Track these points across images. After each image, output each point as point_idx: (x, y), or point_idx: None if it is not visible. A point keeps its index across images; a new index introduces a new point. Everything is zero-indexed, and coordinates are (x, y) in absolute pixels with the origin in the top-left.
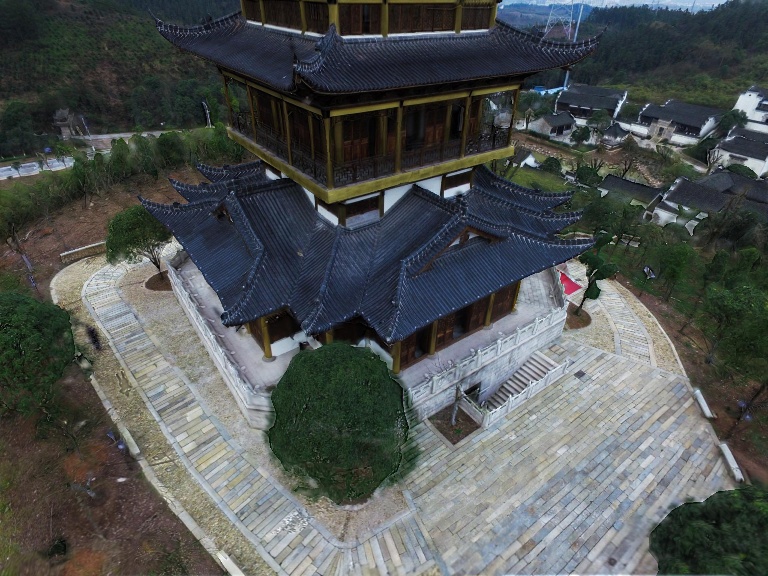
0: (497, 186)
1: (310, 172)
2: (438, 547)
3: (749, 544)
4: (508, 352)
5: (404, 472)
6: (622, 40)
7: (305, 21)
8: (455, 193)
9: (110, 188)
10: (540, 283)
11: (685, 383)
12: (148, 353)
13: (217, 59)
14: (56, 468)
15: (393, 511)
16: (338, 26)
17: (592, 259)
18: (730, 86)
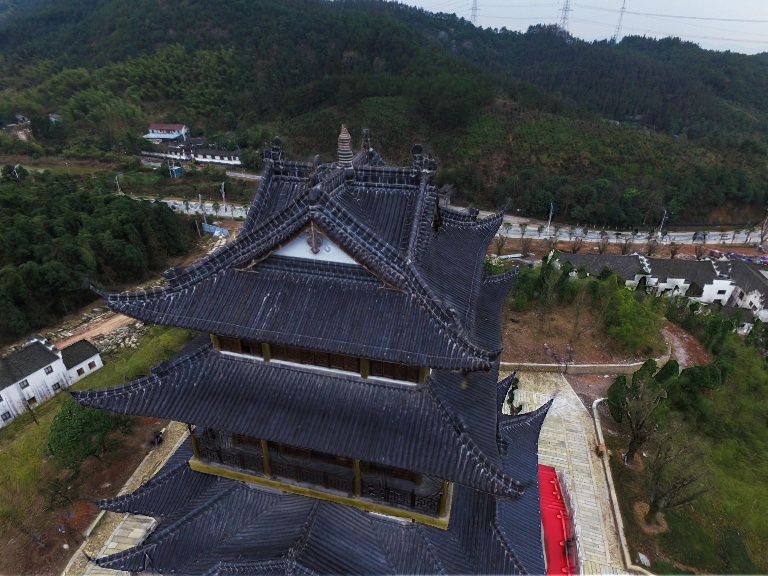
0: (493, 533)
1: None
2: None
3: None
4: None
5: None
6: None
7: None
8: None
9: None
10: None
11: None
12: None
13: None
14: (70, 506)
15: None
16: (218, 343)
17: None
18: None
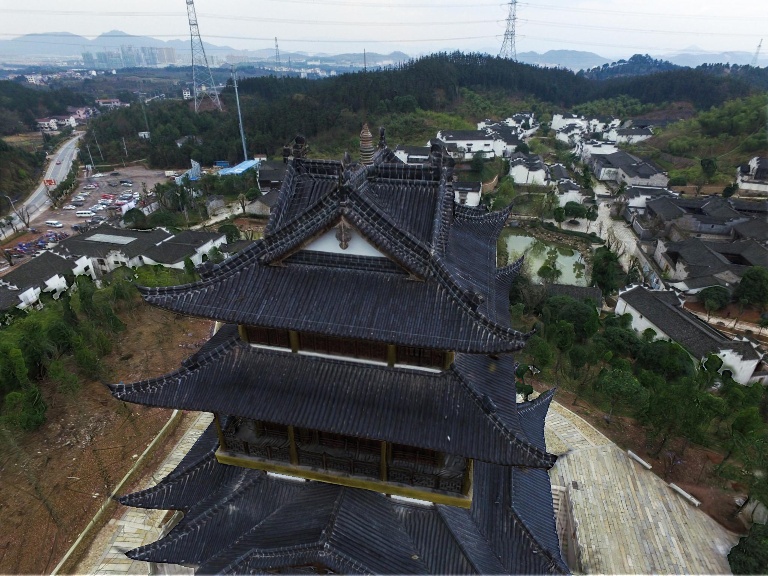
0: None
1: (426, 484)
2: None
3: None
4: None
5: None
6: (276, 112)
7: (394, 356)
8: None
9: None
10: None
11: (617, 448)
12: None
13: (284, 421)
14: None
15: None
16: None
17: (526, 389)
18: None
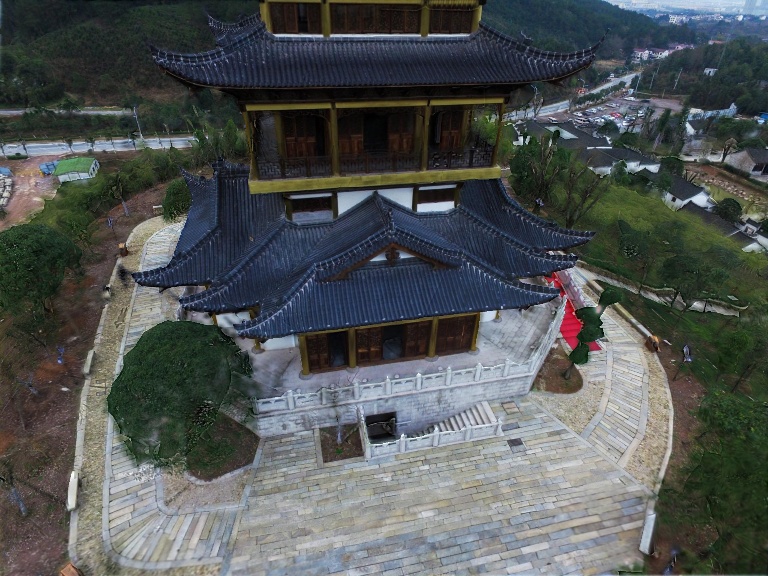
0: (508, 211)
1: None
2: (235, 549)
3: None
4: (433, 390)
5: (261, 469)
6: None
7: None
8: (434, 209)
9: None
10: (531, 330)
11: (647, 500)
12: (154, 298)
13: None
14: (38, 365)
15: (225, 499)
16: (270, 24)
17: (587, 316)
18: None
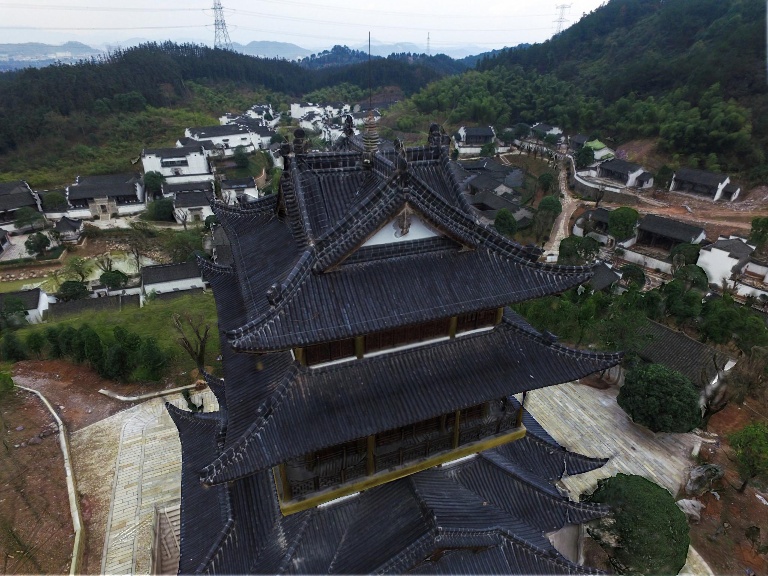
0: None
1: (490, 433)
2: None
3: (664, 390)
4: None
5: None
6: None
7: (455, 327)
8: None
9: None
10: None
11: None
12: None
13: (397, 424)
14: None
15: None
16: None
17: None
18: (112, 151)
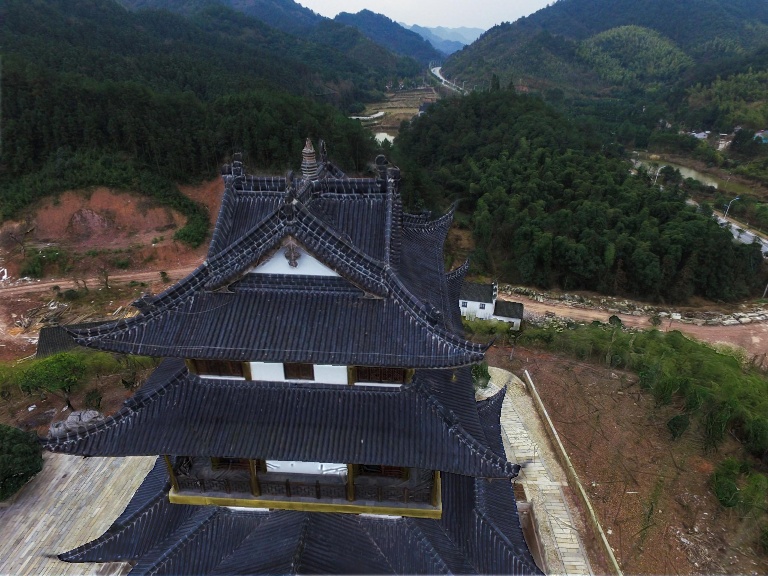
0: None
1: None
2: None
3: None
4: None
5: None
6: None
7: None
8: None
9: (660, 407)
10: None
11: None
12: None
13: None
14: None
15: None
16: None
17: None
18: None
